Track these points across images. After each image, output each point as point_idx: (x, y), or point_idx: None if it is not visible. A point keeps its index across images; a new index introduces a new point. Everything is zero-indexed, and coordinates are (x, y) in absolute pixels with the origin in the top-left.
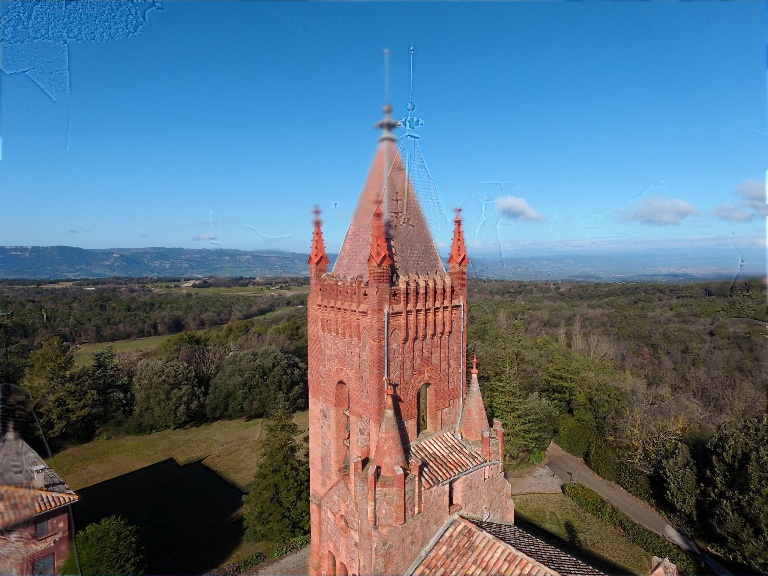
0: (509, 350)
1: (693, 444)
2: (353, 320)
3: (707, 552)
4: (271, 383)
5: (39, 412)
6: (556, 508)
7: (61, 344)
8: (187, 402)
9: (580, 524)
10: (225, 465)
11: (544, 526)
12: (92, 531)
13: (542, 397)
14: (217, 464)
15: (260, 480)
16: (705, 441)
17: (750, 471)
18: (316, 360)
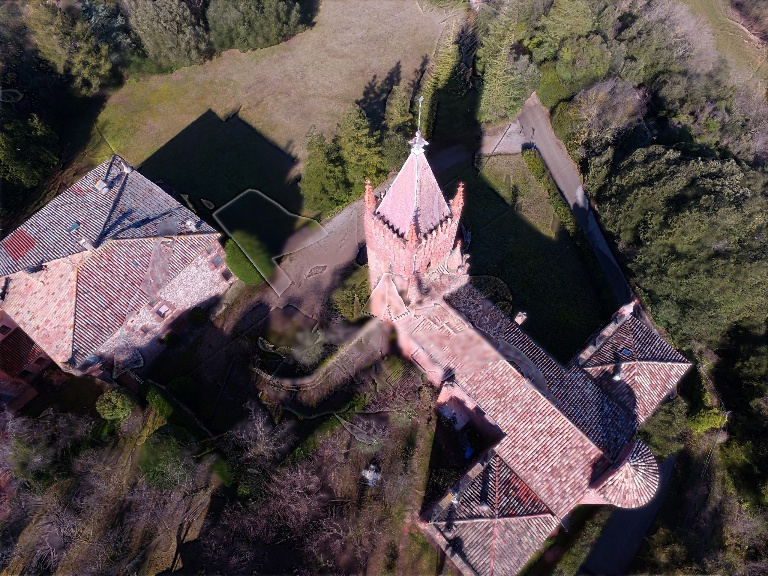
0: (513, 6)
1: (621, 144)
2: (396, 249)
3: (593, 209)
4: (269, 14)
5: (72, 75)
6: (512, 171)
7: (45, 3)
8: (195, 44)
9: (523, 187)
10: (260, 120)
11: (499, 190)
12: (234, 244)
13: (531, 61)
14: (253, 119)
15: (309, 178)
16: (632, 138)
17: (627, 200)
18: (371, 239)
